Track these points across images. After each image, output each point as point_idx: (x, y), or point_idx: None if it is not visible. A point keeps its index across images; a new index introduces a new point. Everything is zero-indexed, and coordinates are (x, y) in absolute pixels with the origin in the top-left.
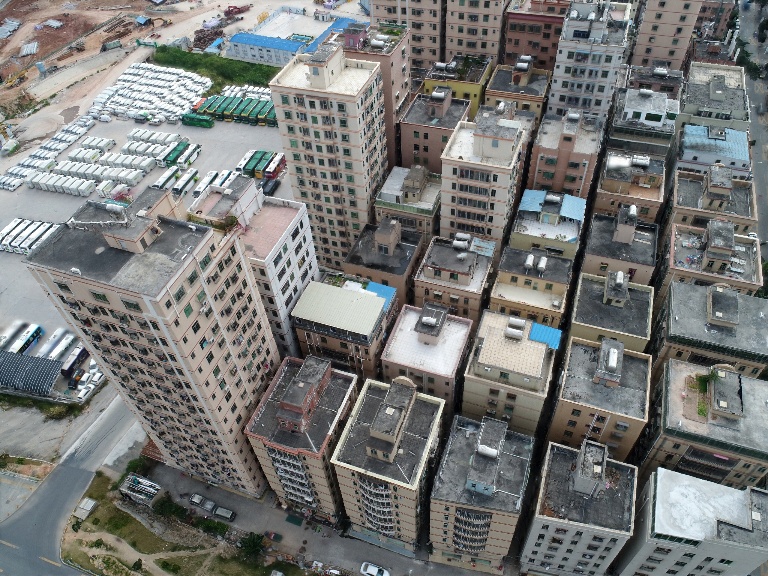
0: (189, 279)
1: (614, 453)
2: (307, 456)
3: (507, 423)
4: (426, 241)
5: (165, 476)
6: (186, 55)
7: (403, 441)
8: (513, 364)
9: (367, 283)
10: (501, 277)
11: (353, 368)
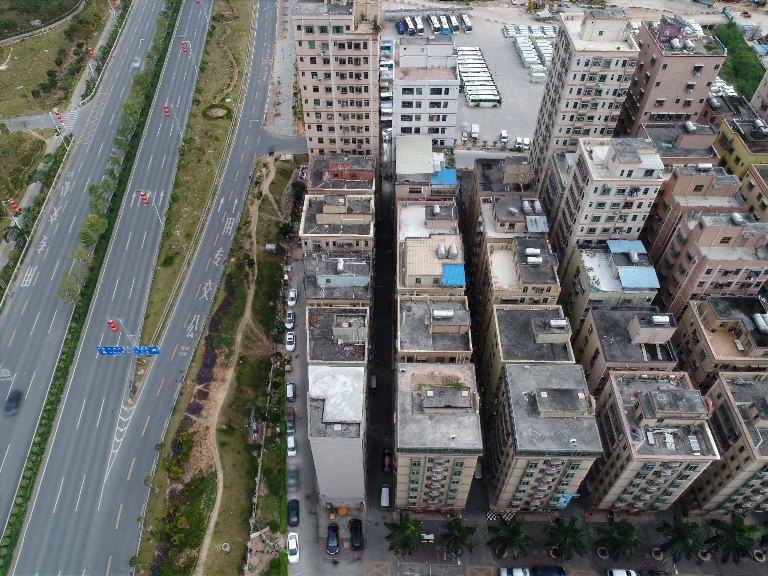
0: (322, 29)
1: None
2: None
3: (369, 274)
4: (553, 213)
5: None
6: (737, 39)
7: (335, 226)
8: (413, 258)
9: None
10: None
11: None
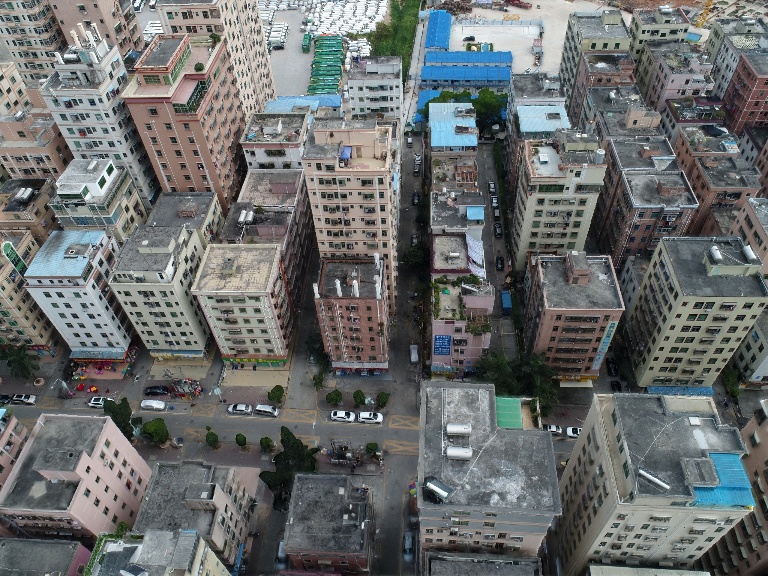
0: None
1: None
2: None
3: None
4: None
5: None
6: (413, 7)
7: None
8: None
9: None
10: None
11: None
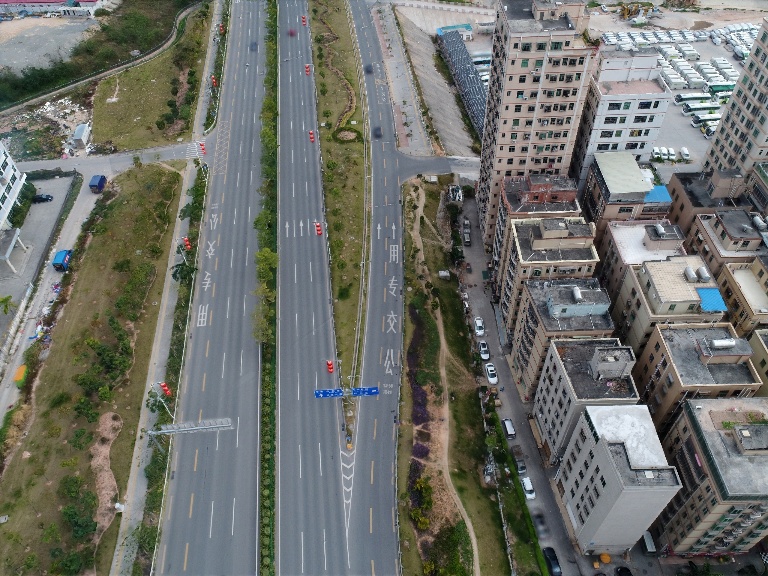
0: (539, 46)
1: (656, 411)
2: (508, 212)
3: (610, 302)
4: None
5: (471, 205)
6: None
7: (552, 251)
8: (661, 283)
9: (662, 185)
10: (755, 265)
11: (594, 222)
